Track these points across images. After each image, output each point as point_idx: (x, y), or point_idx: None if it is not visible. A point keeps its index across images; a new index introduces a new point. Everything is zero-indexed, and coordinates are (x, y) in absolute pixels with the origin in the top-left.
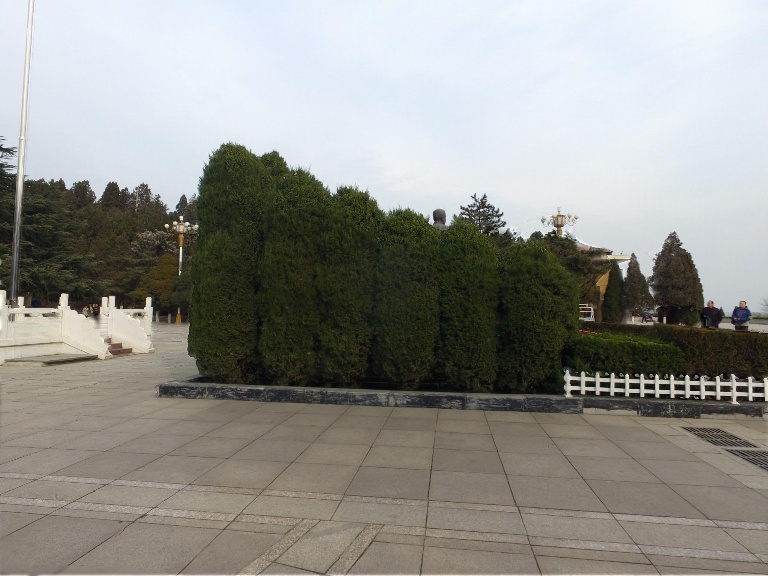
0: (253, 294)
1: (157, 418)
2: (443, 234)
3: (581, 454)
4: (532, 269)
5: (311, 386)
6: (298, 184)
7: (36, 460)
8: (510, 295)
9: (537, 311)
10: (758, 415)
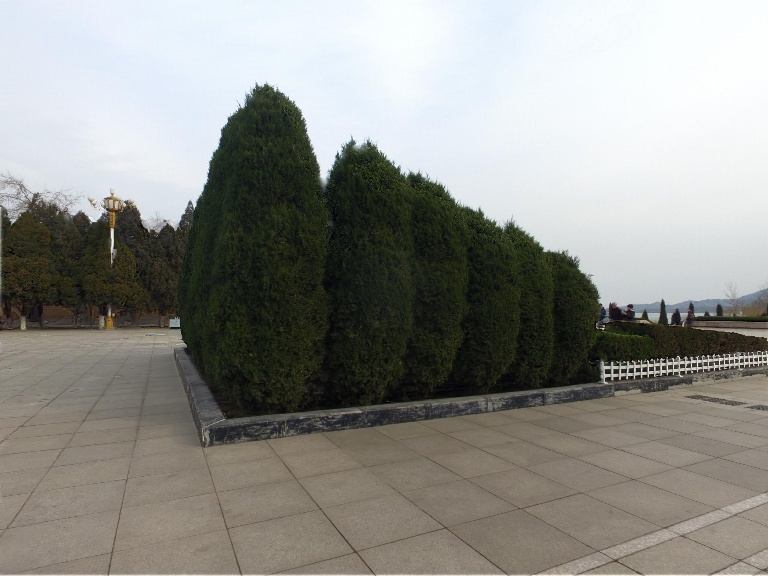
0: (325, 292)
1: (327, 472)
2: (509, 237)
3: (721, 425)
4: (577, 275)
5: (395, 401)
6: (380, 161)
7: (416, 571)
8: (564, 298)
9: (586, 312)
10: (691, 383)
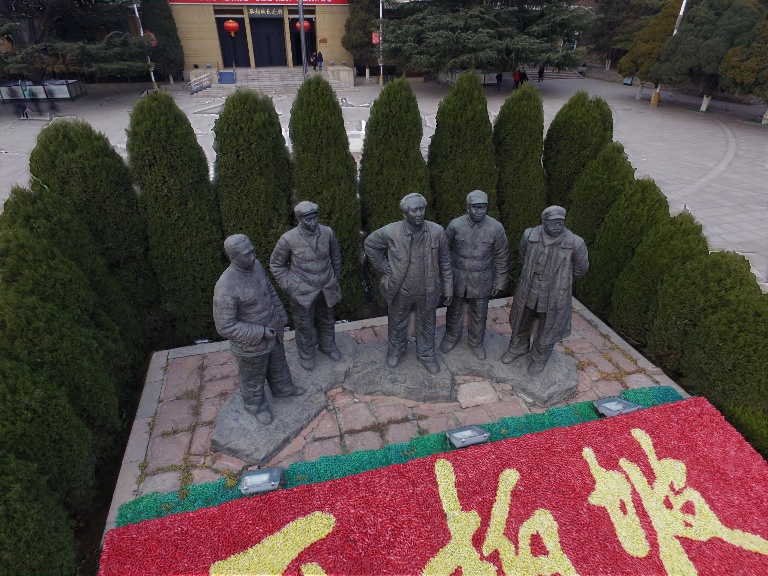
0: None
1: None
2: None
3: None
4: None
5: None
6: None
7: None
8: None
9: None
10: None
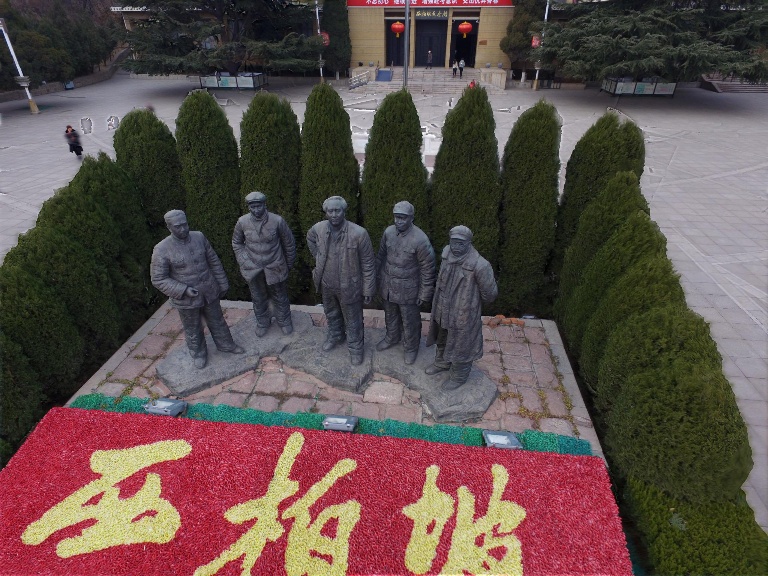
0: None
1: None
2: None
3: None
4: None
5: None
6: None
7: None
8: None
9: None
10: None
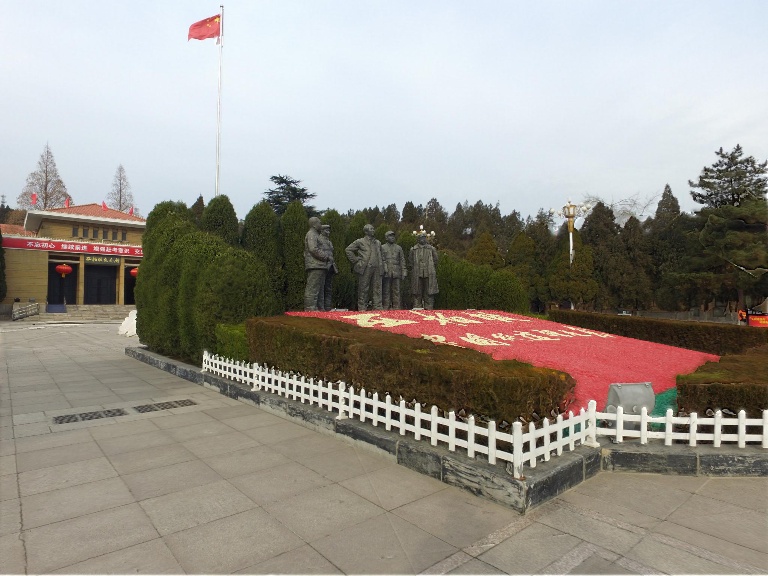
0: None
1: None
2: None
3: None
4: None
5: None
6: None
7: None
8: None
9: None
10: (258, 403)
